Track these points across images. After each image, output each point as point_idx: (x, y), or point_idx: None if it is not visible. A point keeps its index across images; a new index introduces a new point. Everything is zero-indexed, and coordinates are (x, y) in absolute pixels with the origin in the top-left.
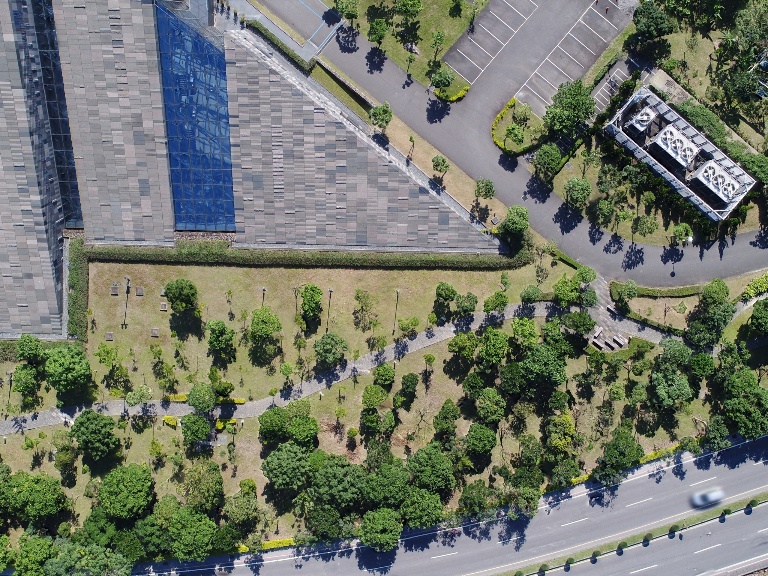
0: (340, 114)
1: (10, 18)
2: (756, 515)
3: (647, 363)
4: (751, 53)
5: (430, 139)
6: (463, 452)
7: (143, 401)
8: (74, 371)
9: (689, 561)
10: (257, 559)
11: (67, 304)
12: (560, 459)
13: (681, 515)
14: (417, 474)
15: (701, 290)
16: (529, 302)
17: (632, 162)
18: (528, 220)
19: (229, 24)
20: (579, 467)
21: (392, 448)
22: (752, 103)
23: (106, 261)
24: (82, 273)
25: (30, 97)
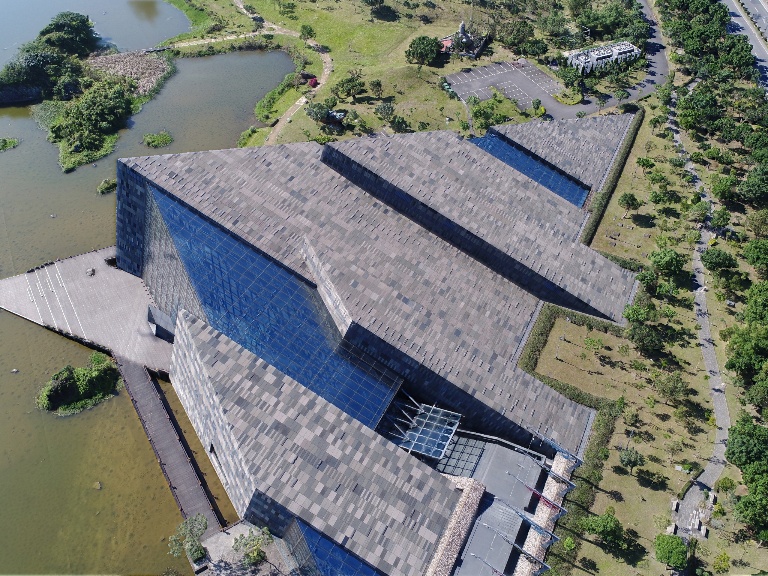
0: None
1: None
2: None
3: None
4: None
5: None
6: None
7: None
8: (671, 253)
9: None
10: None
11: None
12: None
13: None
14: (765, 142)
15: None
16: None
17: None
18: None
19: None
20: None
21: (745, 169)
22: (584, 46)
23: (591, 242)
24: None
25: None
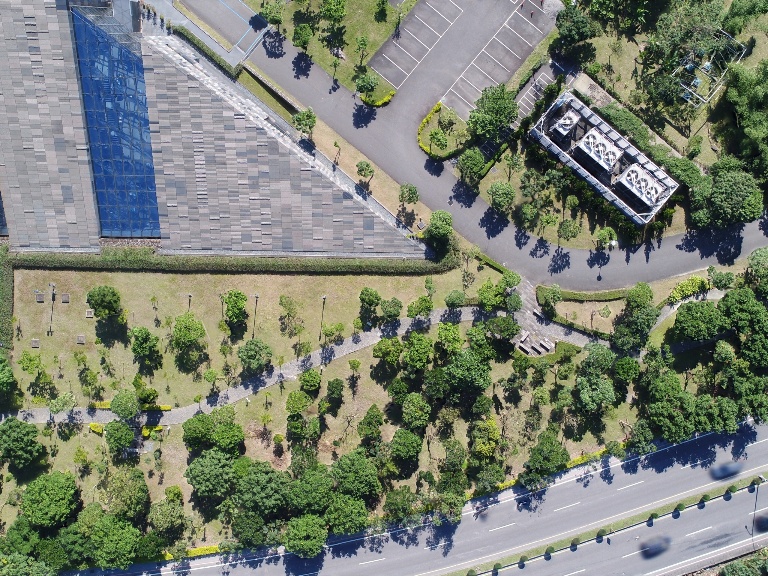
0: (265, 119)
1: None
2: (684, 519)
3: (571, 367)
4: (675, 56)
5: (356, 144)
6: (388, 458)
7: (66, 408)
8: None
9: (617, 565)
10: (184, 566)
11: None
12: (485, 464)
13: (609, 519)
14: (340, 480)
15: None
16: (453, 307)
17: (558, 166)
18: (454, 225)
19: (156, 30)
20: (506, 472)
21: (319, 454)
22: (678, 106)
23: (31, 268)
24: (7, 280)
25: None
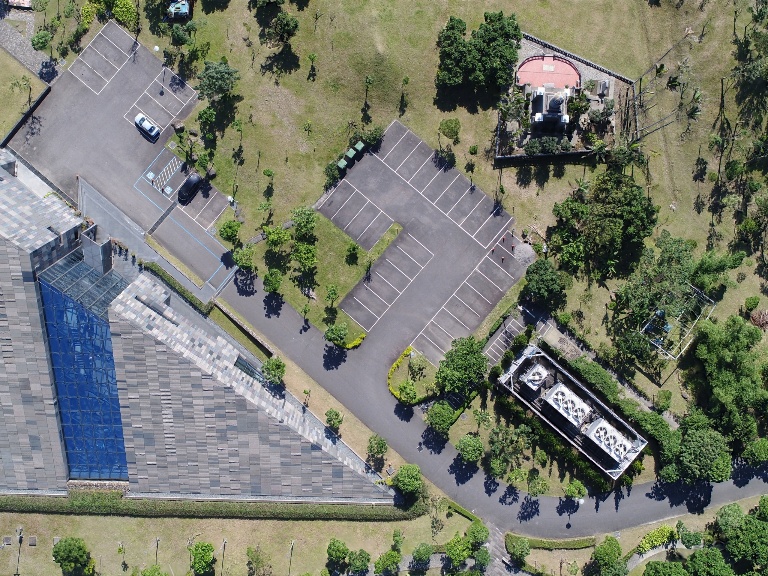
0: (234, 365)
1: None
2: None
3: None
4: (645, 308)
5: (326, 386)
6: None
7: None
8: None
9: None
10: None
11: None
12: None
13: None
14: None
15: (597, 542)
16: (421, 561)
17: (527, 413)
18: (423, 471)
19: (127, 266)
20: None
21: None
22: (648, 352)
23: None
24: None
25: None
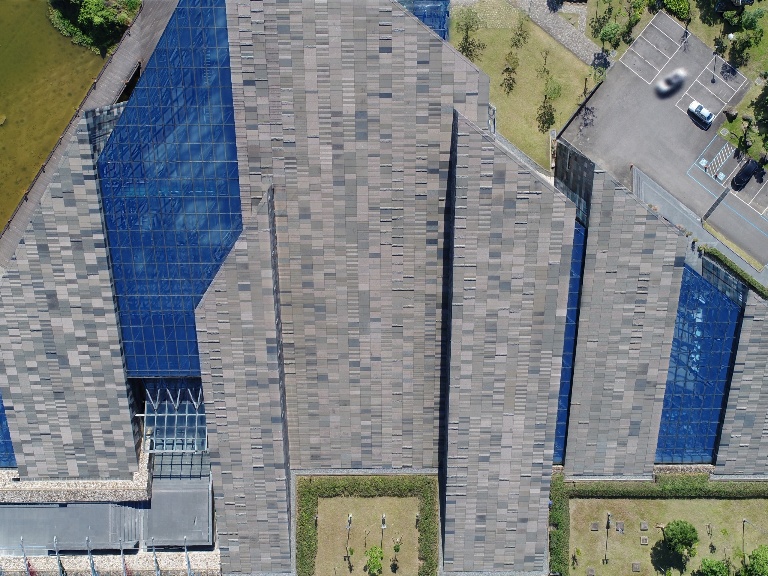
0: None
1: (567, 296)
2: None
3: None
4: None
5: None
6: None
7: None
8: None
9: None
10: None
11: (547, 541)
12: None
13: None
14: None
15: None
16: None
17: None
18: None
19: (687, 252)
20: None
21: None
22: None
23: (585, 497)
24: (565, 511)
25: None
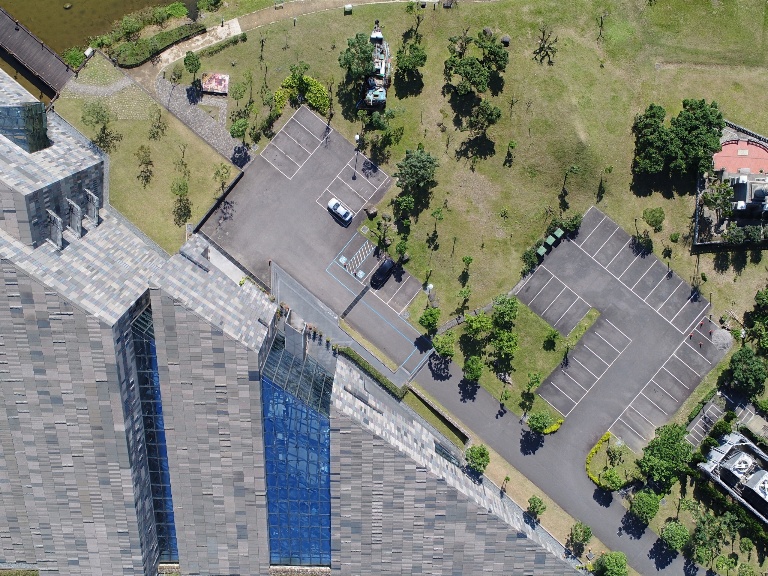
0: (436, 452)
1: (122, 411)
2: None
3: None
4: None
5: (524, 471)
6: None
7: None
8: None
9: None
10: None
11: None
12: None
13: None
14: None
15: None
16: None
17: (727, 498)
18: None
19: (321, 350)
20: None
21: None
22: None
23: None
24: None
25: (136, 469)
